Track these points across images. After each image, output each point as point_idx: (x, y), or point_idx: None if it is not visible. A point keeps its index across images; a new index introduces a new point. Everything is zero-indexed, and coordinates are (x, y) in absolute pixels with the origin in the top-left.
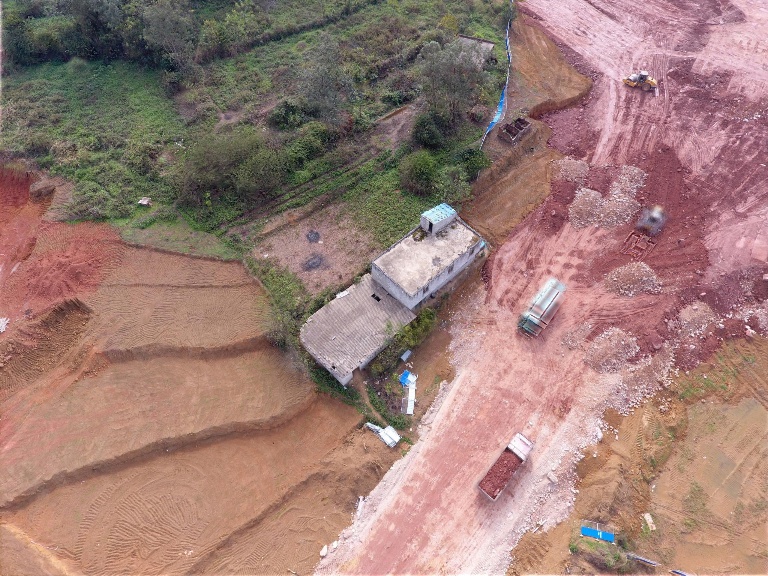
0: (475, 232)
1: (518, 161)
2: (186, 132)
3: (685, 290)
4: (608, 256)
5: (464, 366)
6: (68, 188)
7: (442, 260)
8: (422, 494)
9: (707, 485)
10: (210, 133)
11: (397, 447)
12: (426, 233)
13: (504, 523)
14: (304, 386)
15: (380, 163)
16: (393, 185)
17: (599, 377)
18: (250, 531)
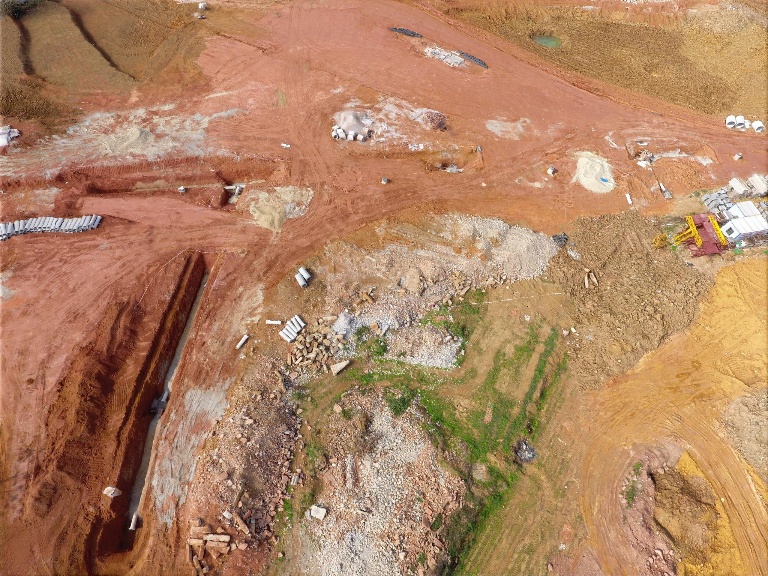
0: None
1: None
2: None
3: None
4: None
5: None
6: None
7: None
8: None
9: None
10: None
11: None
12: None
13: None
14: (46, 3)
15: None
16: None
17: None
18: None
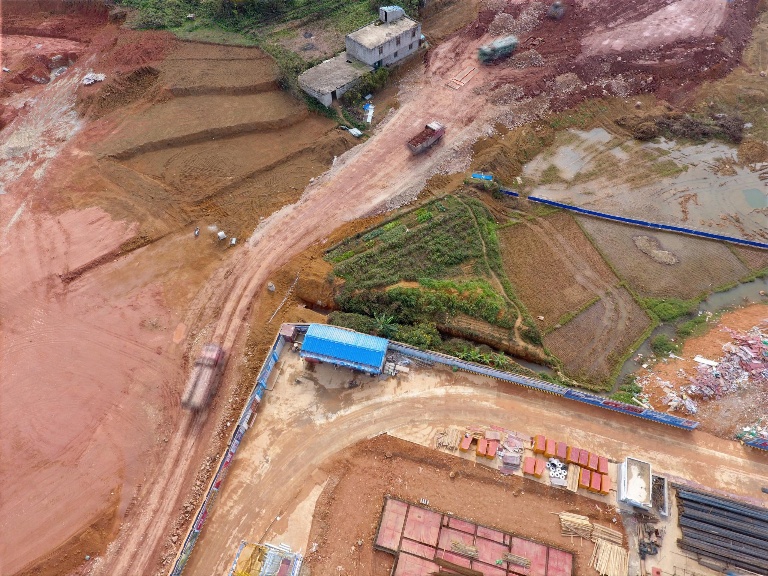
0: (416, 21)
1: (457, 1)
2: None
3: (560, 64)
4: (512, 49)
5: (406, 102)
6: (136, 13)
7: (392, 34)
8: (374, 157)
9: (560, 165)
10: None
11: (360, 139)
12: (383, 22)
13: (423, 167)
14: (300, 106)
15: None
16: (364, 9)
17: (495, 107)
18: (267, 172)
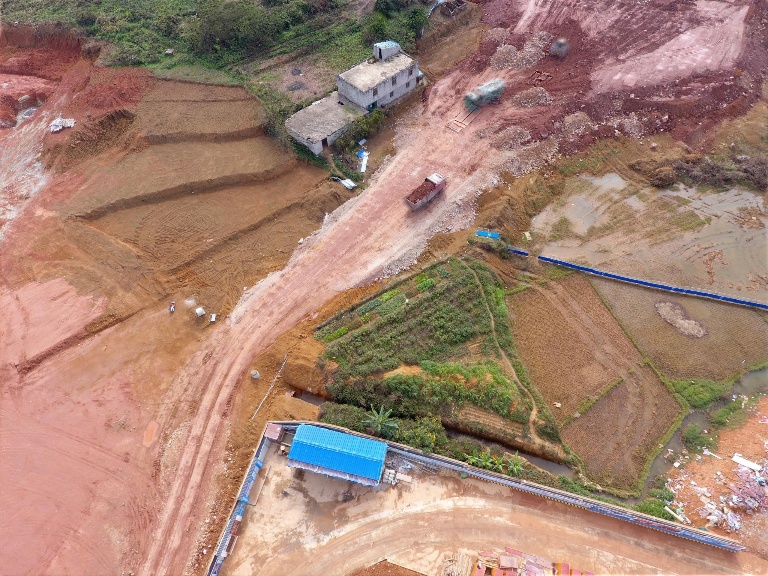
0: (413, 58)
1: (456, 30)
2: (199, 8)
3: (569, 103)
4: (516, 85)
5: (404, 148)
6: (111, 47)
7: (388, 73)
8: (369, 213)
9: (572, 218)
10: (218, 9)
11: (353, 191)
12: (377, 60)
13: (423, 225)
14: (288, 155)
15: (348, 28)
16: (357, 41)
17: (500, 153)
18: (251, 232)
